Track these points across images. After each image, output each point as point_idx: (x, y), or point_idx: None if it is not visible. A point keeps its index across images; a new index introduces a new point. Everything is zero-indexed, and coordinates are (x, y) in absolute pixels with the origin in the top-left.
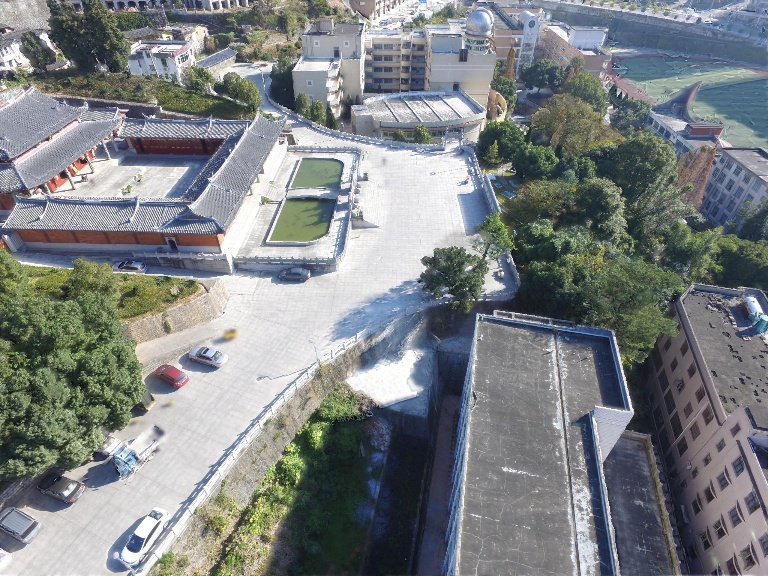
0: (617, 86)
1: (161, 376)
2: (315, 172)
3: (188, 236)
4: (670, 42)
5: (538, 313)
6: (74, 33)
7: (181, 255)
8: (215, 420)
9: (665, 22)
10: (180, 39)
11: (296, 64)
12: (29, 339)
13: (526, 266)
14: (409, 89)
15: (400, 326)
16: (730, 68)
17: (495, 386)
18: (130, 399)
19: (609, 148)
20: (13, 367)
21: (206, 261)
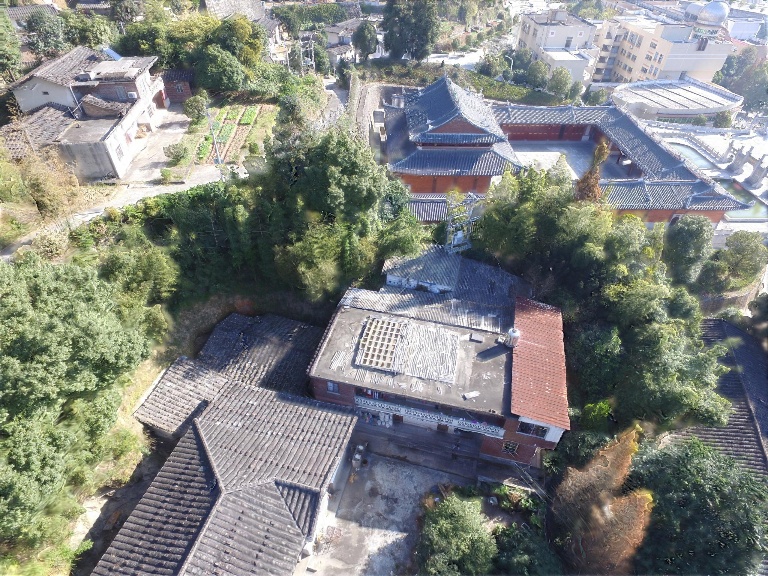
0: None
1: None
2: None
3: (698, 213)
4: None
5: None
6: (403, 22)
7: None
8: None
9: None
10: None
11: (548, 54)
12: None
13: None
14: (601, 79)
15: None
16: None
17: None
18: None
19: None
20: None
21: None
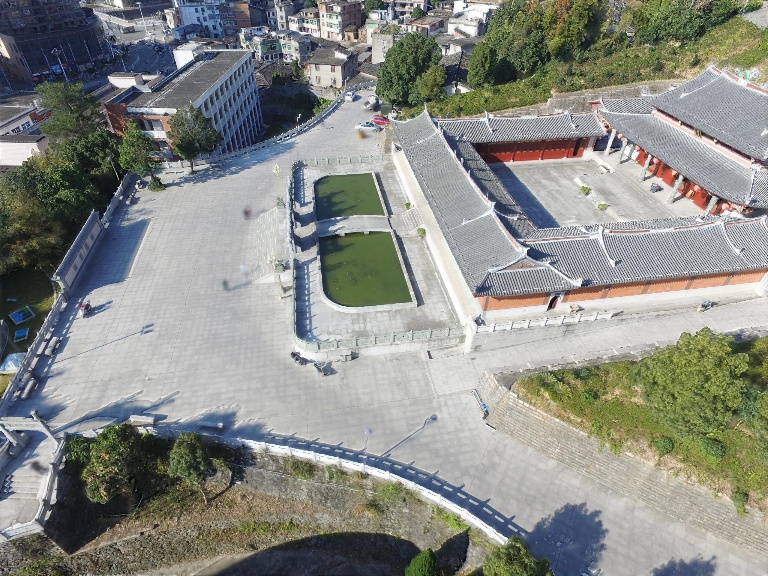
0: None
1: None
2: (371, 272)
3: None
4: None
5: None
6: None
7: None
8: None
9: None
10: None
11: None
12: None
13: None
14: None
15: None
16: None
17: None
18: None
19: None
20: None
21: None
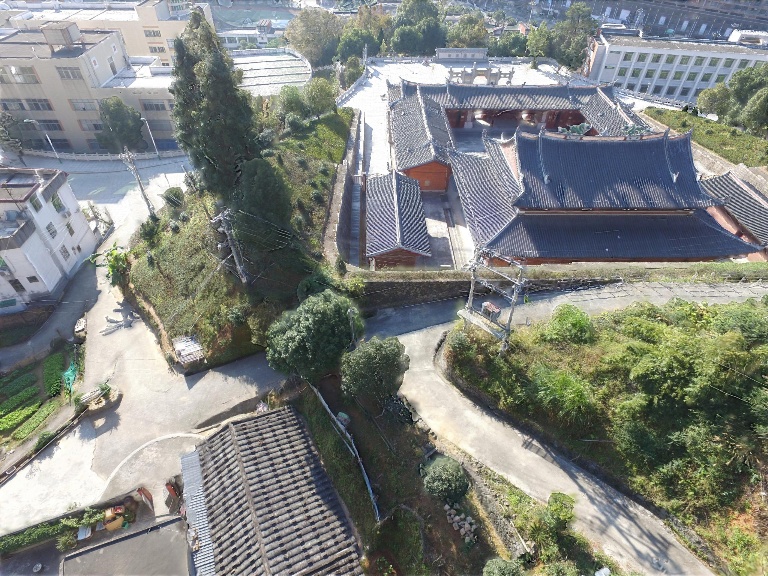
0: None
1: None
2: None
3: None
4: None
5: None
6: None
7: None
8: None
9: None
10: None
11: None
12: None
13: None
14: None
15: None
16: None
17: None
18: None
19: (403, 15)
20: None
21: None
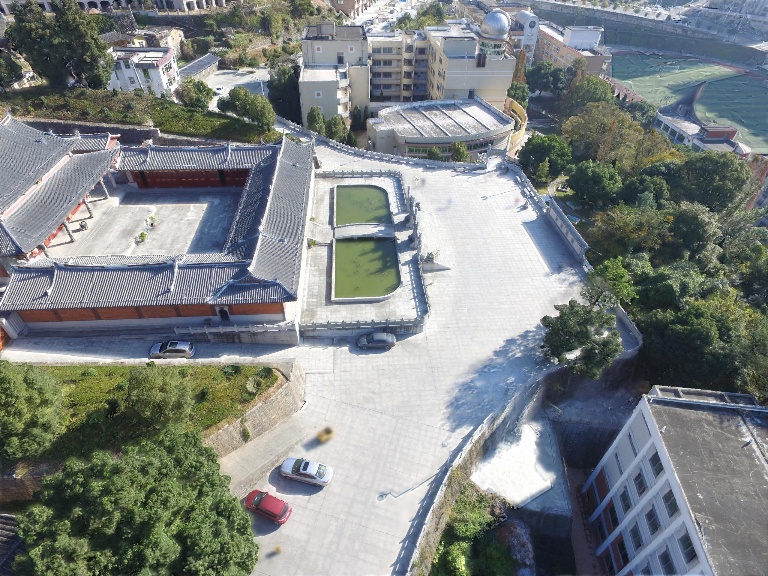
0: (615, 87)
1: (256, 510)
2: (357, 203)
3: (245, 304)
4: (642, 39)
5: (680, 375)
6: (45, 43)
7: (237, 328)
8: (344, 571)
9: (636, 19)
10: (154, 44)
11: None
12: (116, 531)
13: (647, 315)
14: (411, 95)
15: (519, 400)
16: (704, 65)
17: (712, 502)
18: (244, 572)
19: (673, 164)
20: (93, 575)
21: (269, 333)
